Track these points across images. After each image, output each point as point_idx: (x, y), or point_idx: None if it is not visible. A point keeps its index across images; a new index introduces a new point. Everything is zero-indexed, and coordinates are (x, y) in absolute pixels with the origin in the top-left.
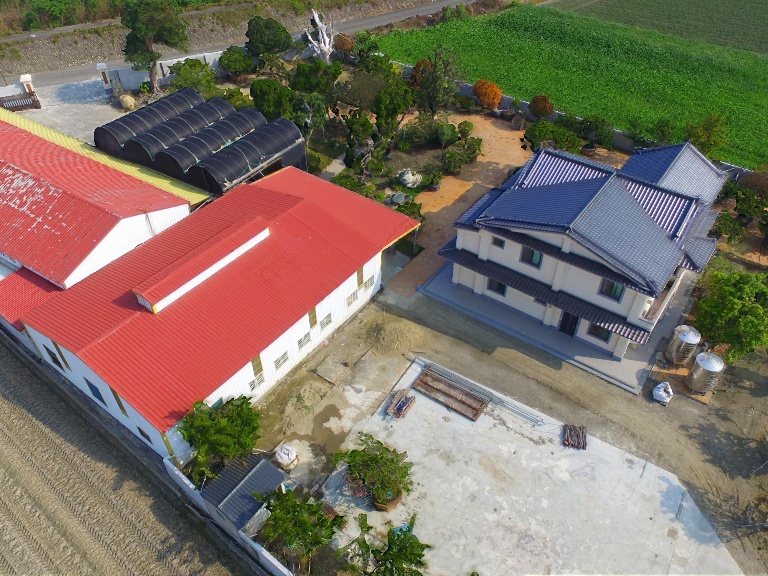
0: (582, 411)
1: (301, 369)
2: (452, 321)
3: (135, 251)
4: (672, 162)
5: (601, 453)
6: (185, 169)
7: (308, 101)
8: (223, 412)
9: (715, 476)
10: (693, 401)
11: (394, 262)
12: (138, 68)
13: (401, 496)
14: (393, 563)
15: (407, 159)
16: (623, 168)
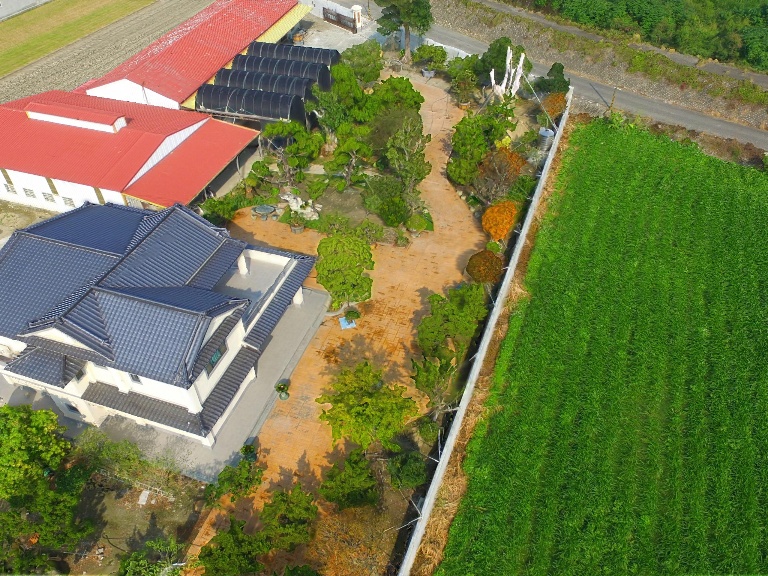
0: None
1: (44, 213)
2: None
3: (117, 101)
4: None
5: None
6: None
7: None
8: None
9: None
10: None
11: None
12: (379, 30)
13: None
14: None
15: (350, 204)
16: None
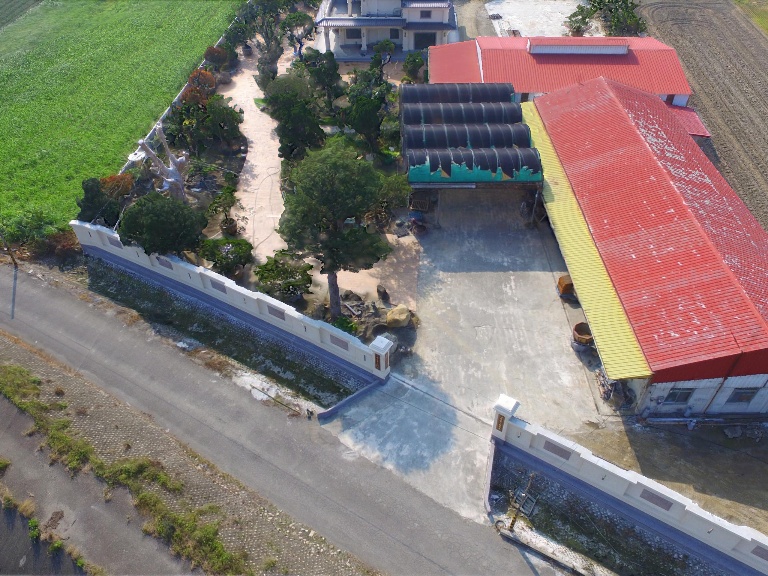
0: None
1: None
2: None
3: None
4: None
5: None
6: None
7: None
8: None
9: (475, 1)
10: None
11: None
12: None
13: None
14: None
15: None
16: None
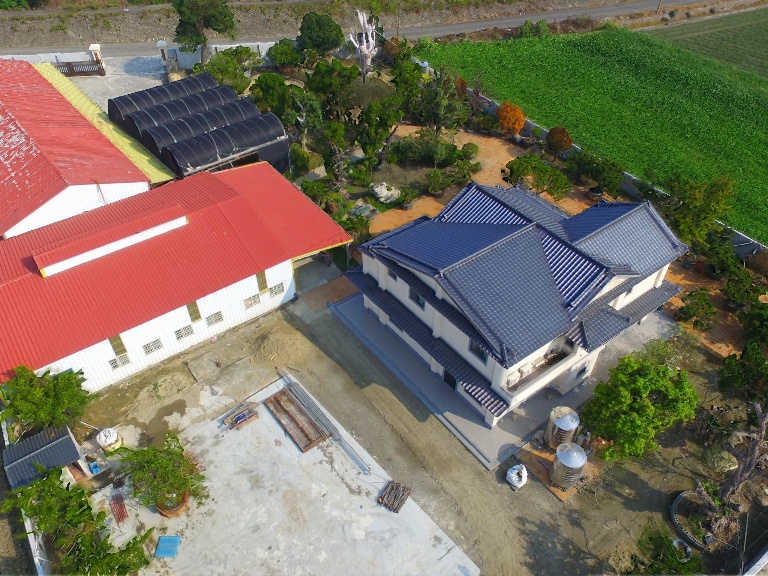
0: (420, 471)
1: (178, 359)
2: (344, 345)
3: (76, 217)
4: (610, 222)
5: (412, 521)
6: (161, 149)
7: (300, 100)
8: (41, 381)
9: None
10: (550, 494)
11: (324, 274)
12: (184, 49)
13: (190, 506)
14: (90, 568)
15: (397, 173)
16: (569, 219)
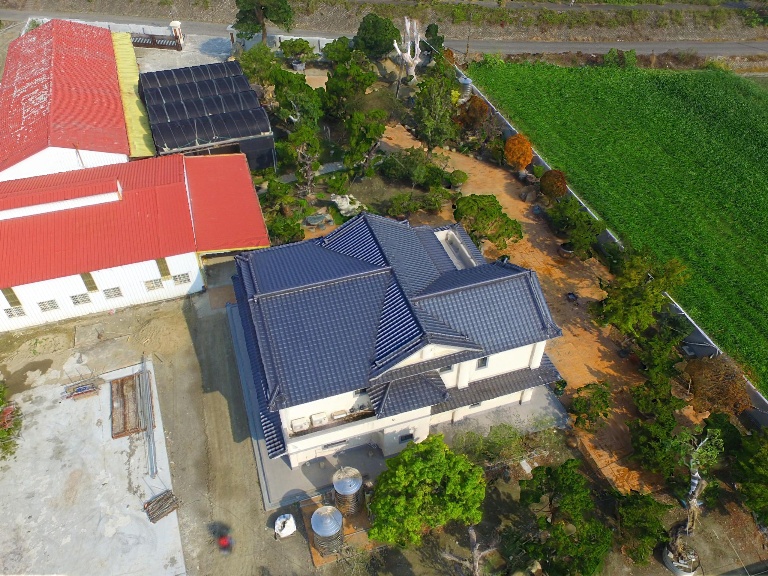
0: (203, 490)
1: (73, 322)
2: (216, 347)
3: (49, 175)
4: (471, 284)
5: (162, 535)
6: None
7: (293, 100)
8: None
9: None
10: (308, 554)
11: None
12: (240, 35)
13: None
14: None
15: (377, 188)
16: (454, 271)
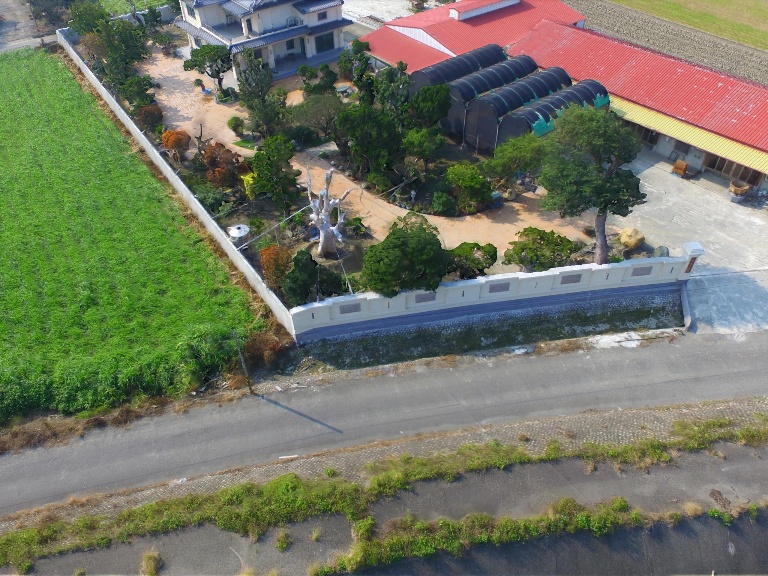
0: None
1: None
2: None
3: None
4: None
5: None
6: None
7: (397, 71)
8: None
9: None
10: None
11: None
12: None
13: None
14: None
15: None
16: None
